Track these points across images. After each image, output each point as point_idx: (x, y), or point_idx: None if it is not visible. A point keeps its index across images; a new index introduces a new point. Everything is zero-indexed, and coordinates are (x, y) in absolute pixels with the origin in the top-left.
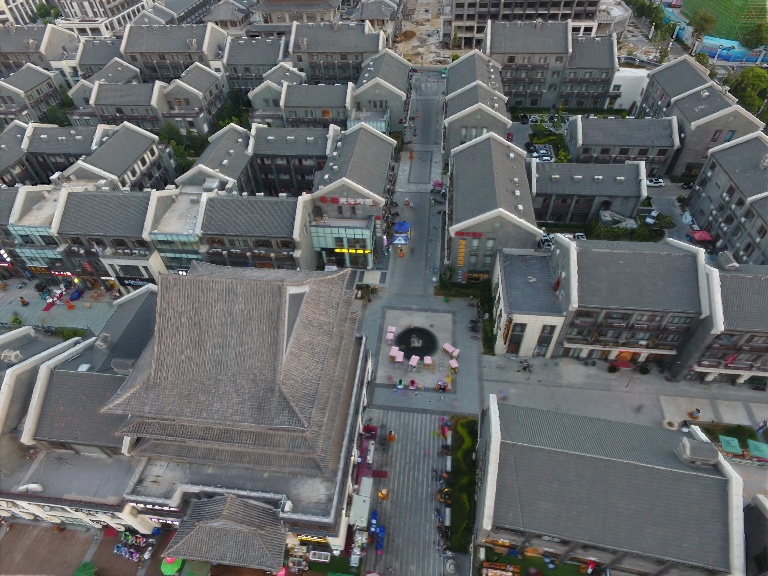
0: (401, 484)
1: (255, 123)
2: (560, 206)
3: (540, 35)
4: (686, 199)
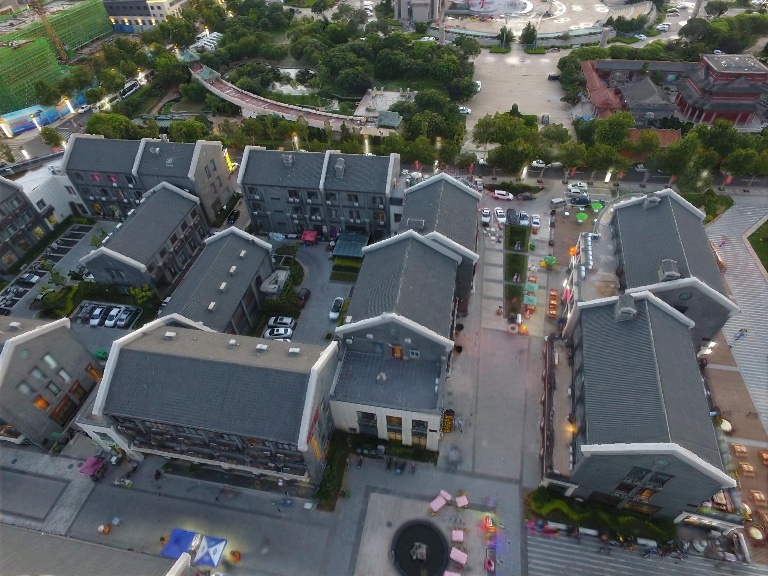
0: None
1: None
2: (238, 321)
3: None
4: (253, 227)
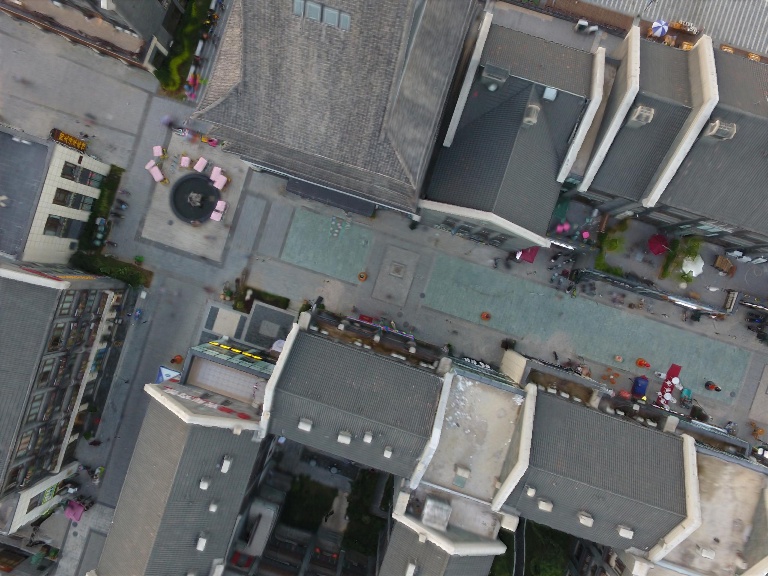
0: None
1: None
2: None
3: None
4: None
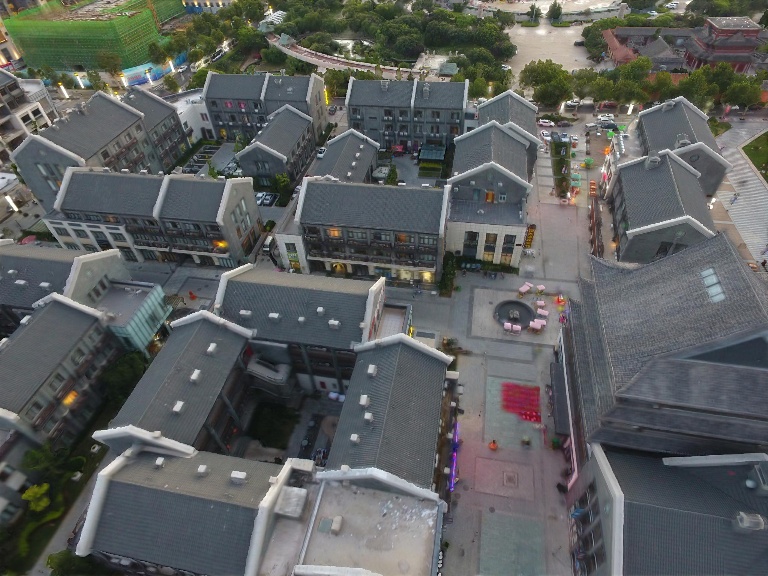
0: None
1: (129, 426)
2: None
3: (97, 118)
4: None
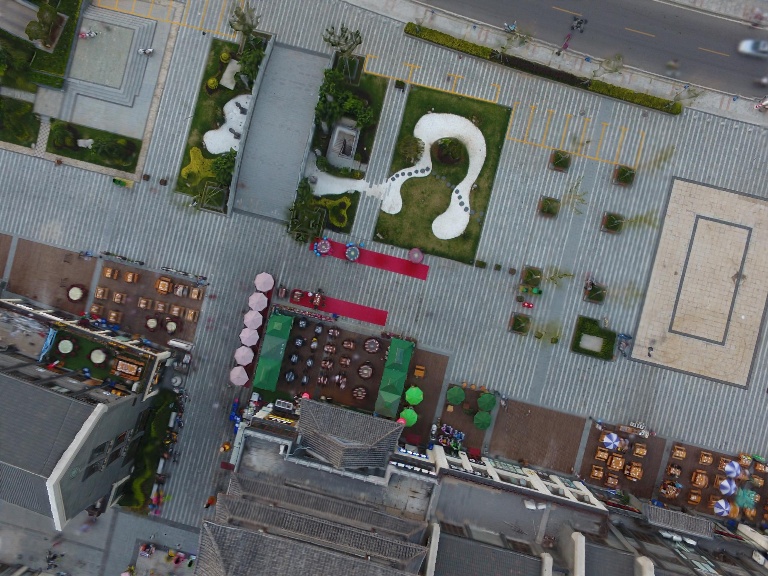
0: (210, 454)
1: None
2: None
3: None
4: None
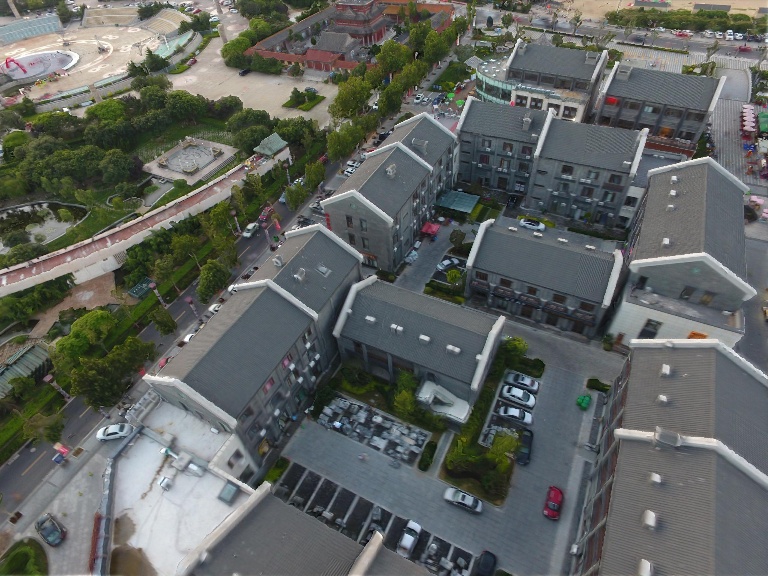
0: None
1: None
2: None
3: None
4: None
